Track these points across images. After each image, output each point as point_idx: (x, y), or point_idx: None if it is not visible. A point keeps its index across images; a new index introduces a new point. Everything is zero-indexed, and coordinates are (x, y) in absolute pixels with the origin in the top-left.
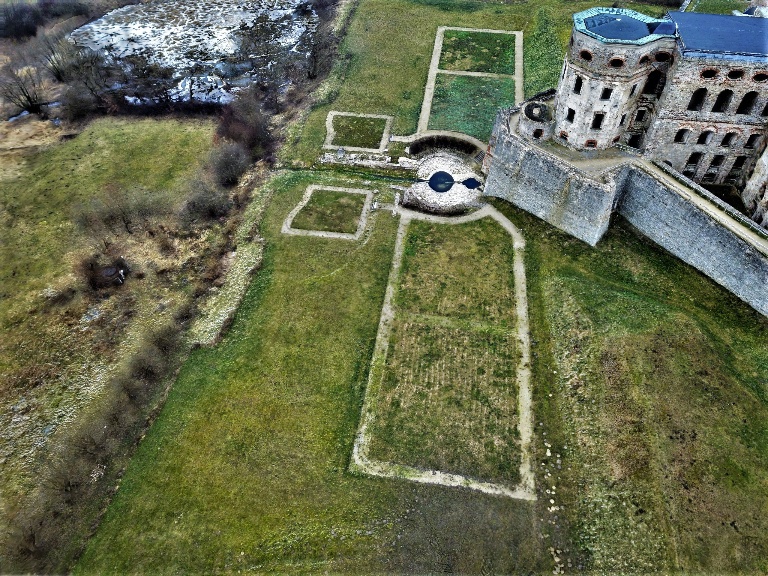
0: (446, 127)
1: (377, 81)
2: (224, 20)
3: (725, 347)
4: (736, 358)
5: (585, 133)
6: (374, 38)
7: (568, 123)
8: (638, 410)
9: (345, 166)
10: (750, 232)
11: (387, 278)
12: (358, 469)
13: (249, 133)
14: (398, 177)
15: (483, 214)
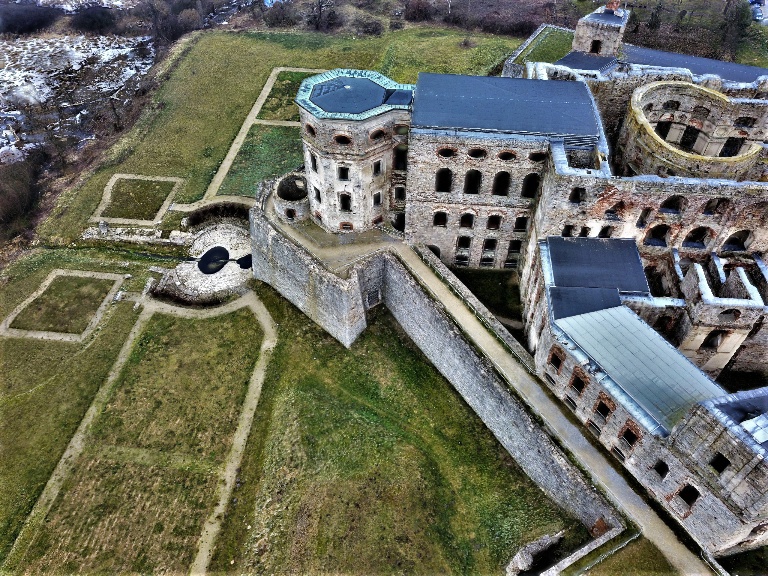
0: (238, 191)
1: (181, 135)
2: (49, 62)
3: (450, 495)
4: (458, 511)
5: (335, 215)
6: (198, 83)
7: (317, 203)
8: None
9: (109, 242)
10: (495, 344)
11: (94, 396)
12: None
13: (6, 205)
14: (166, 255)
15: (240, 304)
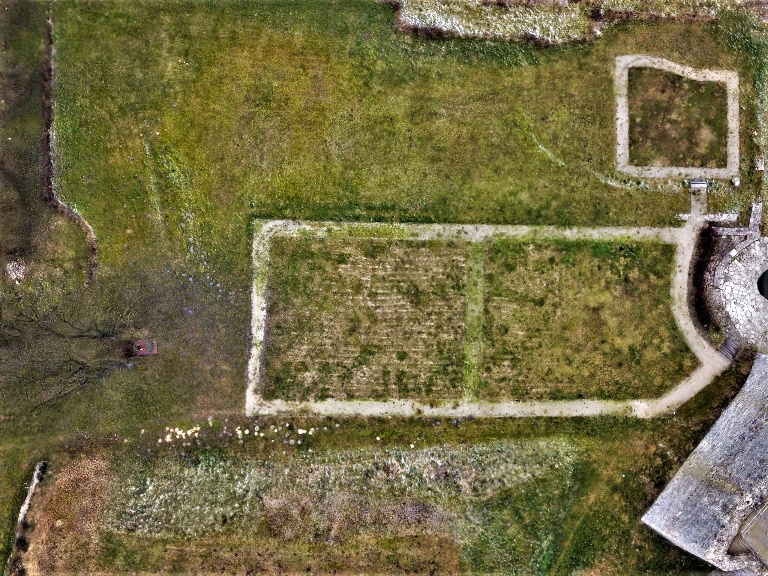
0: None
1: None
2: None
3: None
4: None
5: None
6: None
7: None
8: (343, 538)
9: None
10: None
11: (542, 223)
12: (257, 228)
13: None
14: None
15: (703, 354)
